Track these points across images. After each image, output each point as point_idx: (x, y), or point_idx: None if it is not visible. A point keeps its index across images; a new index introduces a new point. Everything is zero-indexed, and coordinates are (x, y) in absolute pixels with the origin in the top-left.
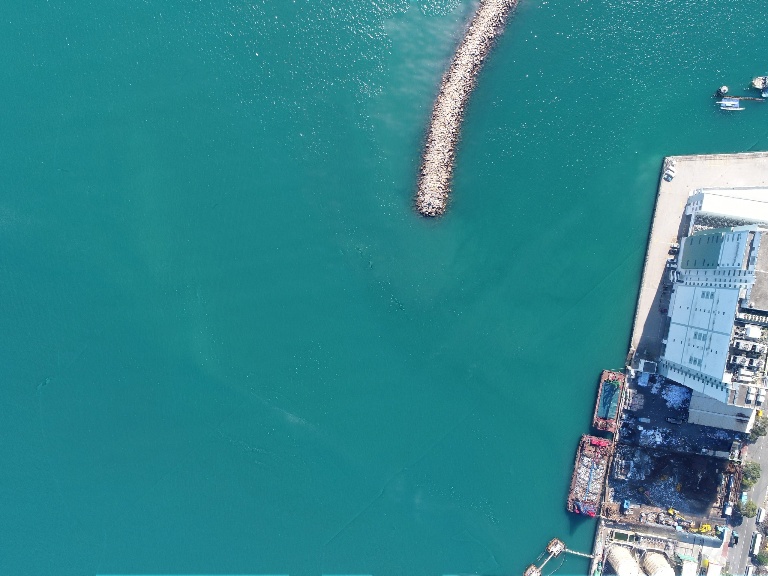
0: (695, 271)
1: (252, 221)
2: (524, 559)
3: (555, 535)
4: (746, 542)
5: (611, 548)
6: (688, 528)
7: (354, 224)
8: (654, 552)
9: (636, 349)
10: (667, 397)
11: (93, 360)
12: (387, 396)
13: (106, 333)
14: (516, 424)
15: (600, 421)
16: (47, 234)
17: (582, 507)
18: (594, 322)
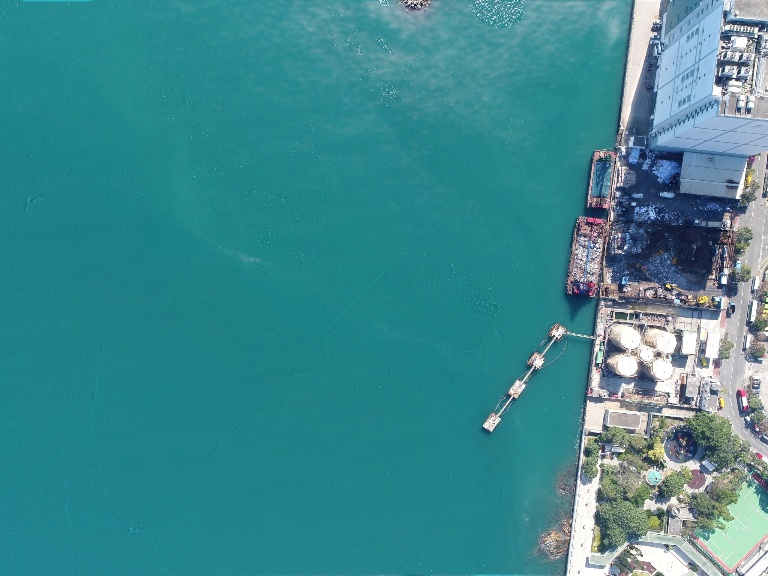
0: (679, 30)
1: (238, 7)
2: (527, 347)
3: (556, 321)
4: (743, 312)
5: (612, 327)
6: (686, 301)
7: (341, 8)
8: (654, 328)
9: (625, 128)
10: (658, 173)
11: (82, 176)
12: (383, 176)
13: (94, 145)
14: (512, 214)
15: (594, 199)
16: (29, 51)
17: (581, 284)
18: (583, 105)
